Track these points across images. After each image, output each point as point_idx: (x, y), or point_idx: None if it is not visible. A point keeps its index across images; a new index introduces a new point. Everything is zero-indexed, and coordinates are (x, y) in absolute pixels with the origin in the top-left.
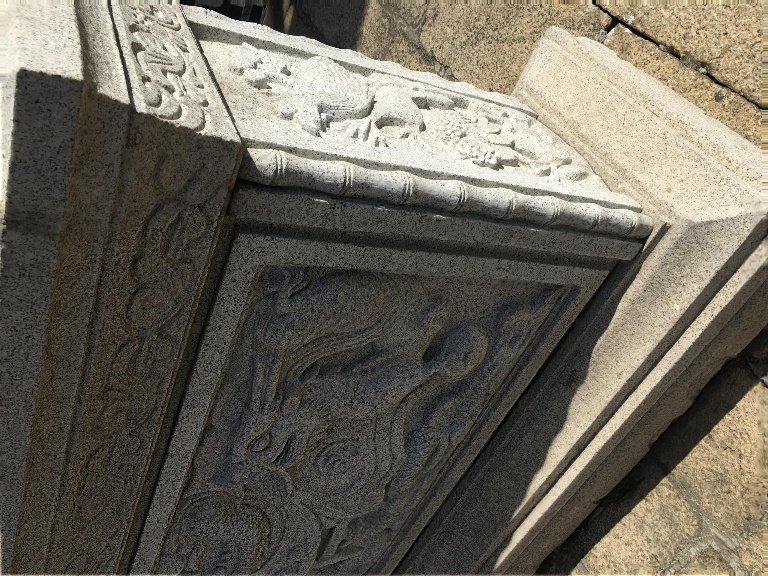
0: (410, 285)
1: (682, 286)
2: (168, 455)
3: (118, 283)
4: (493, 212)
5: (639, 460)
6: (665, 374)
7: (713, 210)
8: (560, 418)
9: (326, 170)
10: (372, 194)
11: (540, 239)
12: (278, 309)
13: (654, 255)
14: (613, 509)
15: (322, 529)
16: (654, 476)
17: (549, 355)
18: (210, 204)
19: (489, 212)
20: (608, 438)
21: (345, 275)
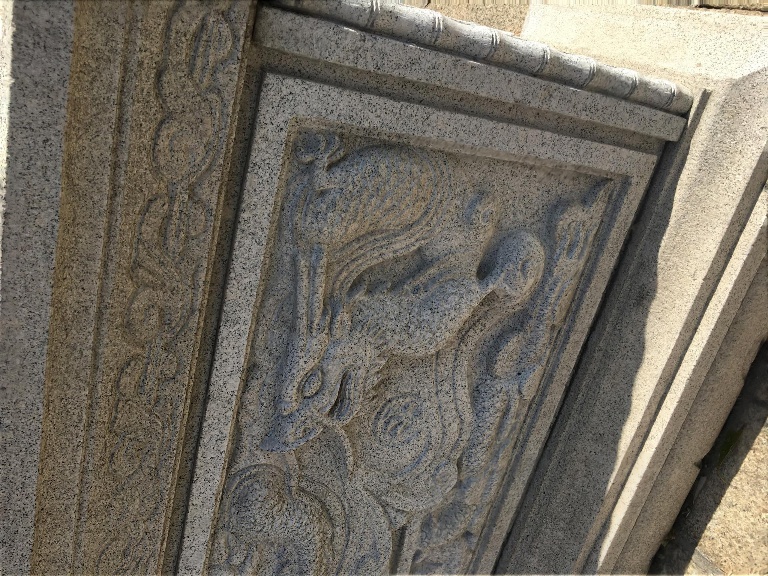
0: (452, 169)
1: (739, 153)
2: (209, 398)
3: (142, 97)
4: (528, 62)
5: (735, 399)
6: (744, 261)
7: (752, 64)
8: (638, 348)
9: None
10: (401, 28)
11: (581, 102)
12: (316, 183)
13: (701, 128)
14: (718, 474)
15: (392, 531)
16: (756, 418)
17: (611, 277)
18: (235, 12)
19: (524, 62)
20: (697, 358)
21: (383, 148)
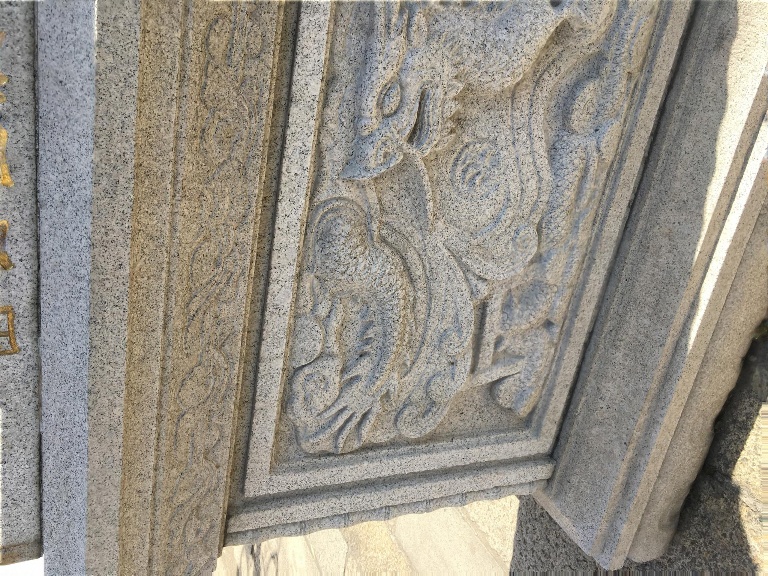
0: None
1: None
2: (292, 101)
3: None
4: None
5: None
6: None
7: None
8: (720, 97)
9: None
10: None
11: None
12: None
13: None
14: None
15: (473, 304)
16: None
17: (687, 24)
18: None
19: None
20: None
21: None
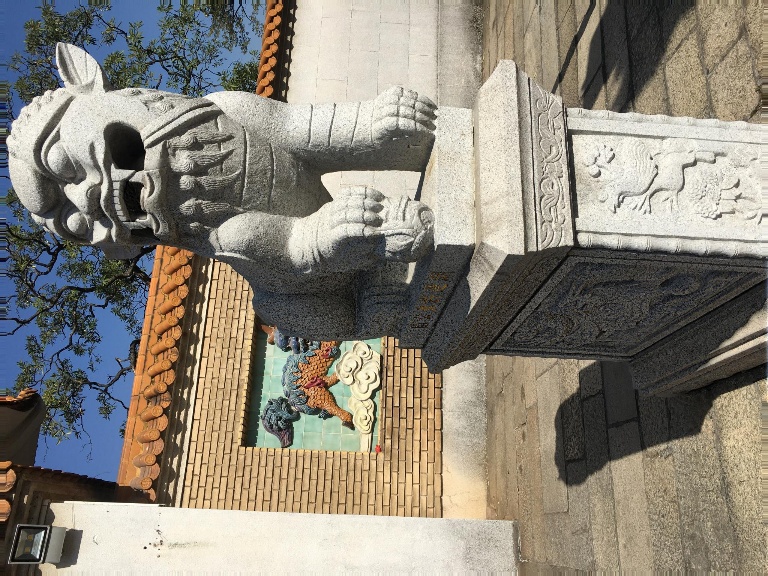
0: None
1: None
2: (531, 301)
3: None
4: (696, 254)
5: None
6: None
7: None
8: (744, 320)
9: (610, 244)
10: (630, 249)
11: (726, 262)
12: None
13: None
14: None
15: (600, 330)
16: None
17: None
18: None
19: None
20: None
21: None
